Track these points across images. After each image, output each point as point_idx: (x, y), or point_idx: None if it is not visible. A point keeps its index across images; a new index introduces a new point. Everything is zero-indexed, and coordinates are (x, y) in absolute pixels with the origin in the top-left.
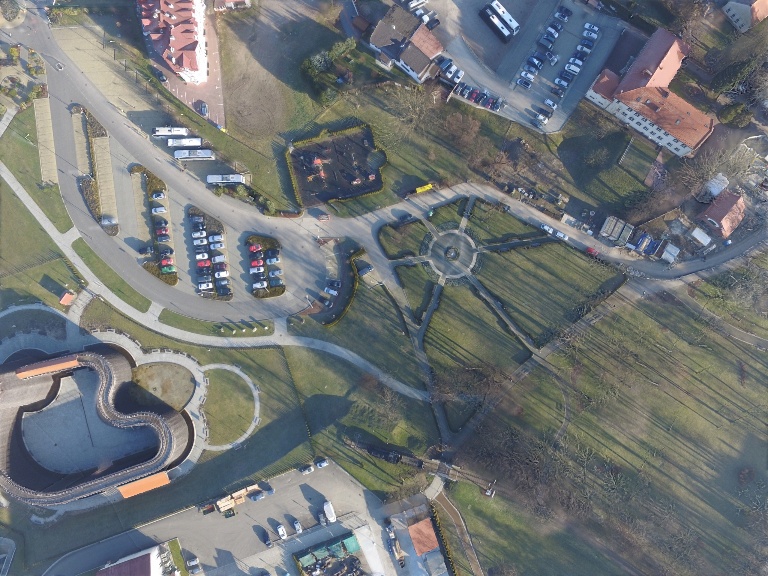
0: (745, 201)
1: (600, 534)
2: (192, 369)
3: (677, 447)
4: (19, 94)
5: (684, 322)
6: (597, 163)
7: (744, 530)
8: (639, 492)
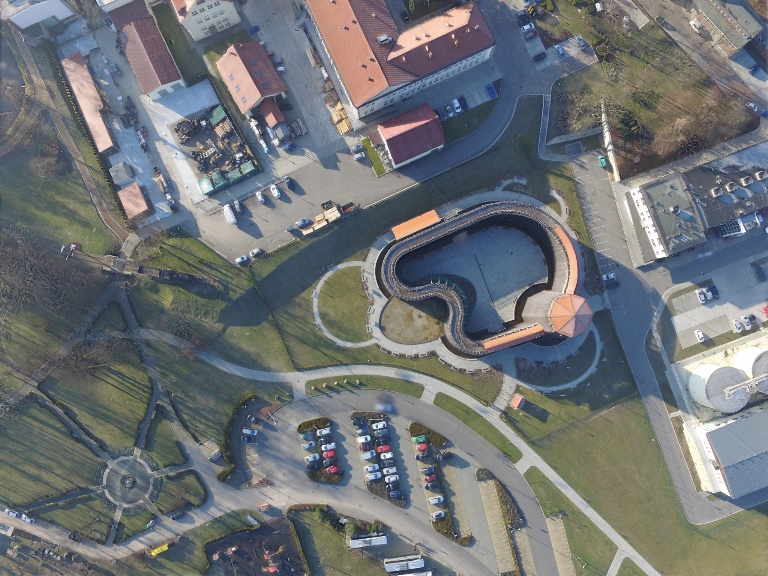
0: None
1: None
2: (385, 340)
3: None
4: None
5: None
6: None
7: None
8: None
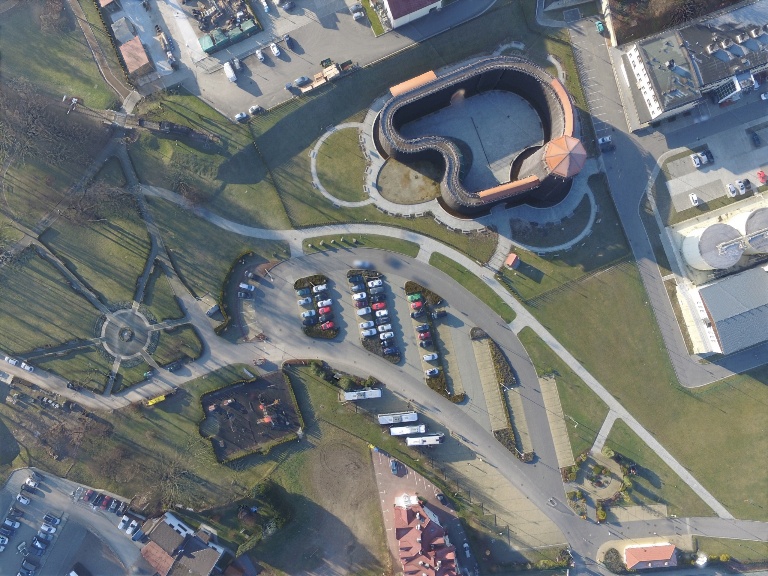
0: None
1: None
2: (381, 200)
3: None
4: (591, 470)
5: None
6: None
7: None
8: None
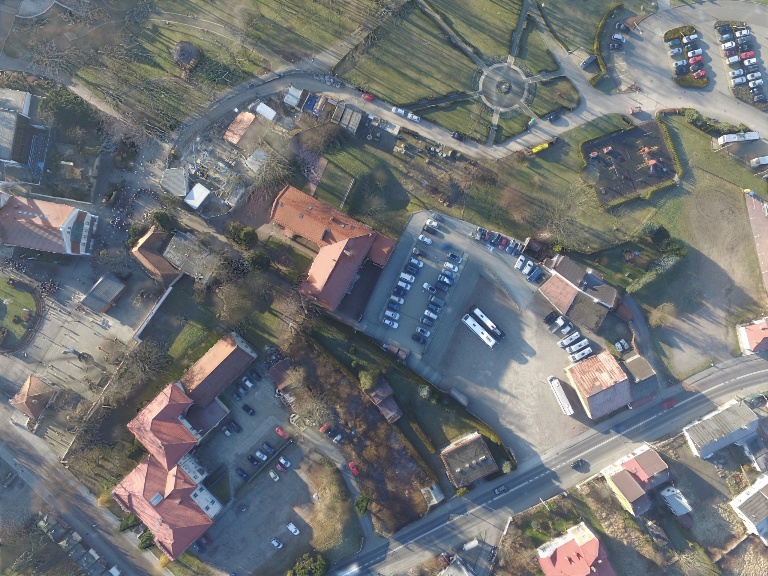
0: (224, 152)
1: None
2: None
3: None
4: None
5: (271, 35)
6: (373, 183)
7: None
8: None
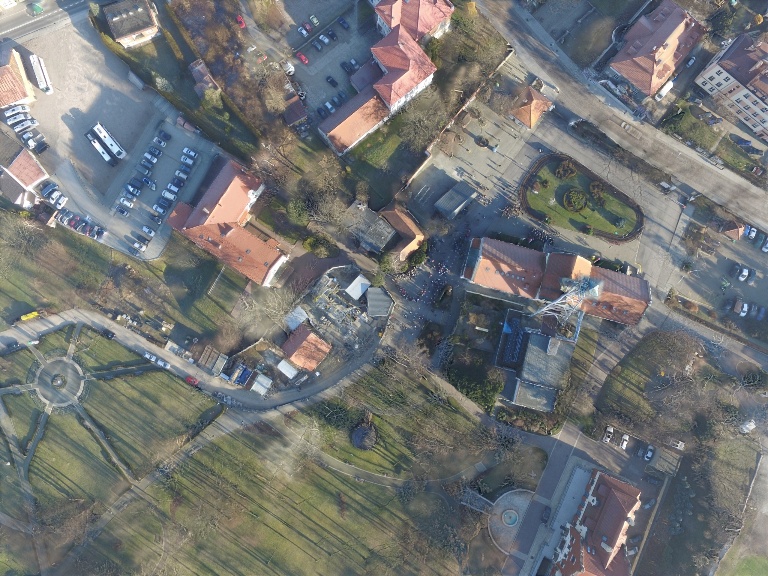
0: (333, 332)
1: None
2: None
3: None
4: None
5: (282, 453)
6: (193, 291)
7: None
8: None
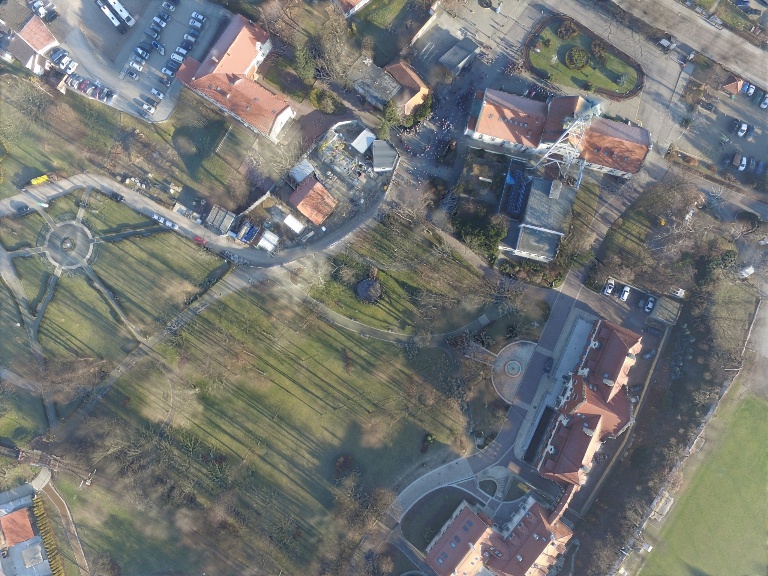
0: (339, 187)
1: (198, 523)
2: None
3: (281, 435)
4: None
5: (288, 310)
6: (201, 151)
7: (338, 518)
8: (243, 481)
